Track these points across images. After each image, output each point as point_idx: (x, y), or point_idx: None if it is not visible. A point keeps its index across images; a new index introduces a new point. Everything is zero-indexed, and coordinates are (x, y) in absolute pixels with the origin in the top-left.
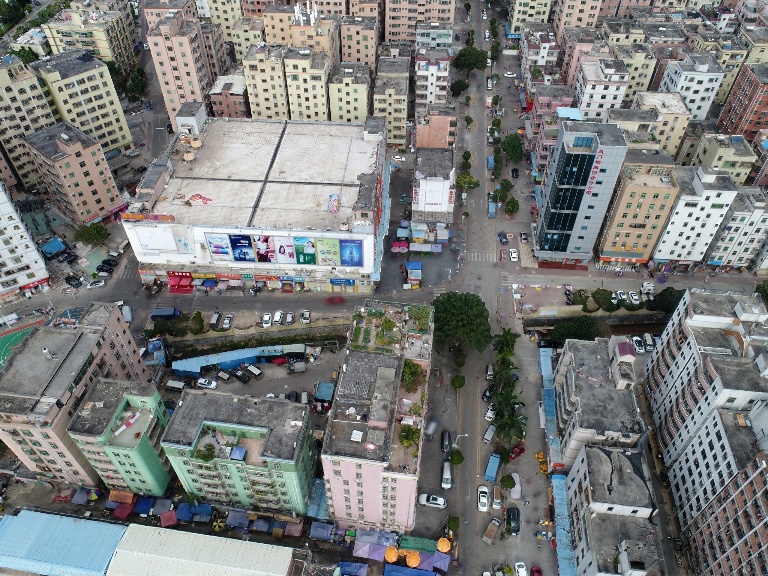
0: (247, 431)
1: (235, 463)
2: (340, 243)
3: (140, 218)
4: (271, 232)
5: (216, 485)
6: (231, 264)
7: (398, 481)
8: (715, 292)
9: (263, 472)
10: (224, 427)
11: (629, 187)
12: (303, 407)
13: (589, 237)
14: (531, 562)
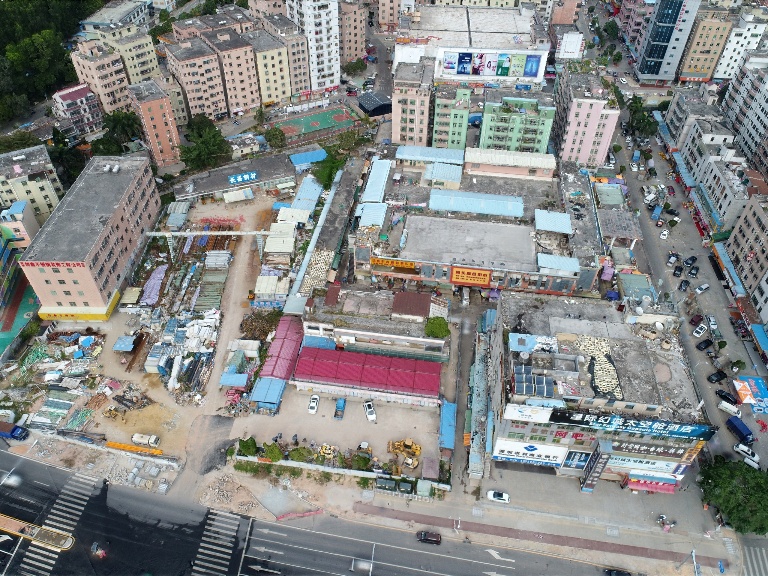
0: (525, 103)
1: (522, 115)
2: (527, 58)
3: (407, 42)
4: (486, 50)
5: (502, 138)
6: (453, 77)
7: (608, 117)
8: (760, 52)
9: (536, 119)
10: (513, 101)
11: (702, 22)
12: (550, 95)
13: (674, 63)
14: (666, 186)
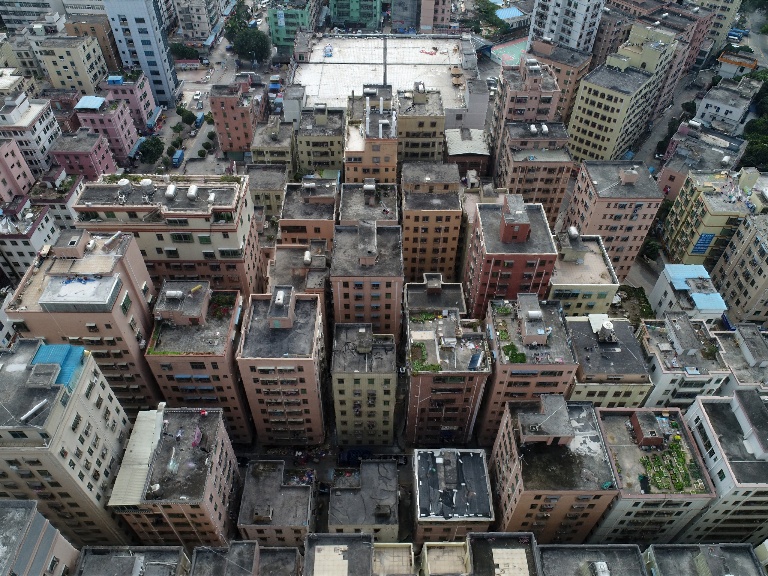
0: None
1: None
2: None
3: (457, 32)
4: None
5: None
6: None
7: None
8: None
9: None
10: None
11: None
12: None
13: None
14: None
